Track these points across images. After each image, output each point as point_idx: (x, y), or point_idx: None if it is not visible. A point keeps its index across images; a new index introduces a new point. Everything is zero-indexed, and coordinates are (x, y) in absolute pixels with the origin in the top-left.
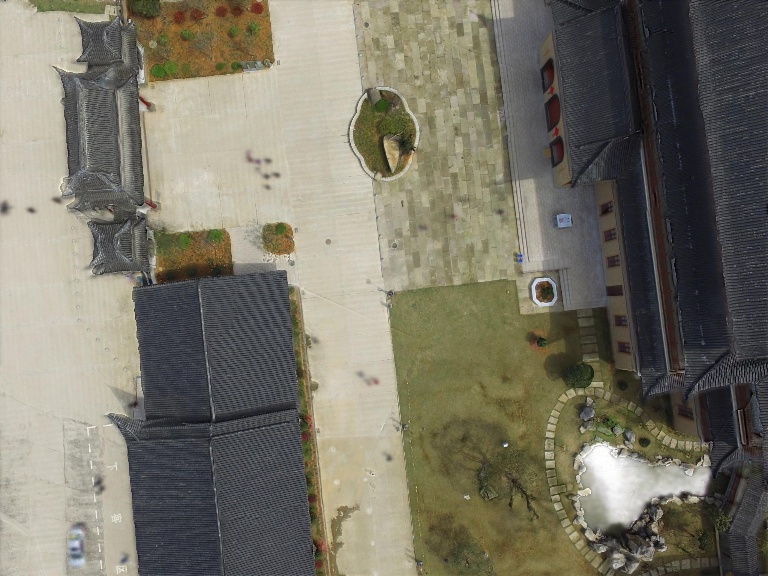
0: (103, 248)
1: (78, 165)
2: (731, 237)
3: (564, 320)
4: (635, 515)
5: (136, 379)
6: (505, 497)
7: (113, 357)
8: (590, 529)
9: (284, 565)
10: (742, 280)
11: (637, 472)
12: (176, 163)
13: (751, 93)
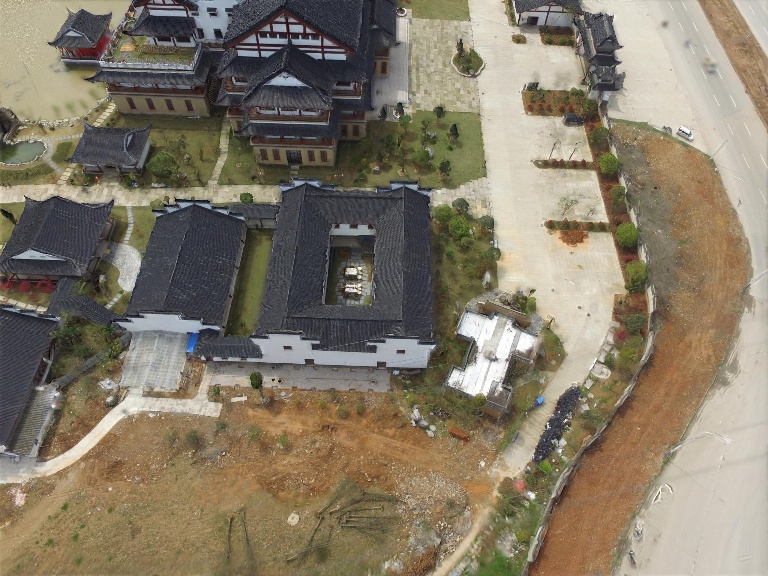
0: None
1: None
2: None
3: None
4: None
5: None
6: None
7: None
8: None
9: None
10: None
11: None
12: (569, 66)
13: None
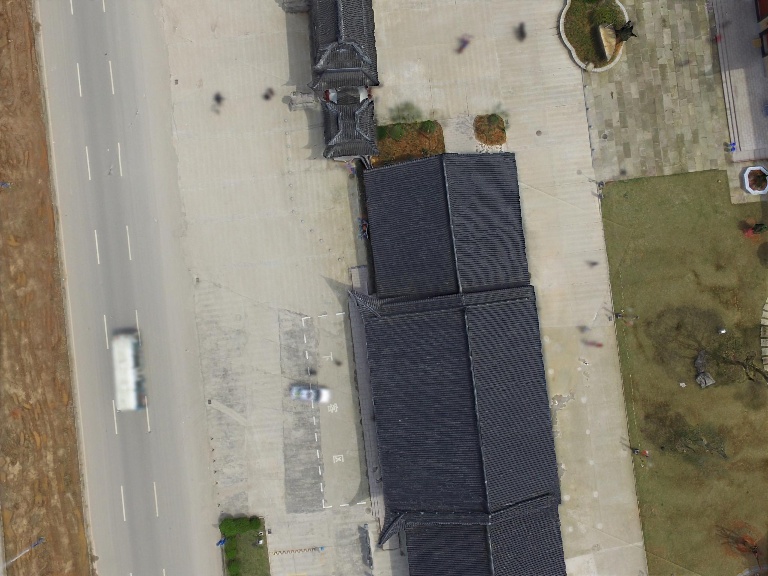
0: (343, 126)
1: (338, 33)
2: None
3: None
4: None
5: (351, 270)
6: (722, 384)
7: (327, 248)
8: None
9: (528, 439)
10: None
11: None
12: (387, 56)
13: None
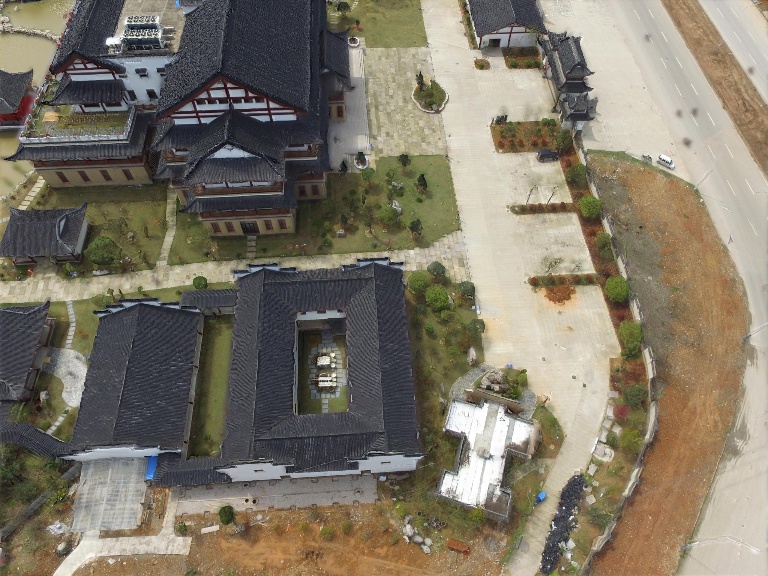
0: None
1: None
2: None
3: None
4: None
5: None
6: None
7: None
8: None
9: None
10: None
11: None
12: (537, 91)
13: None
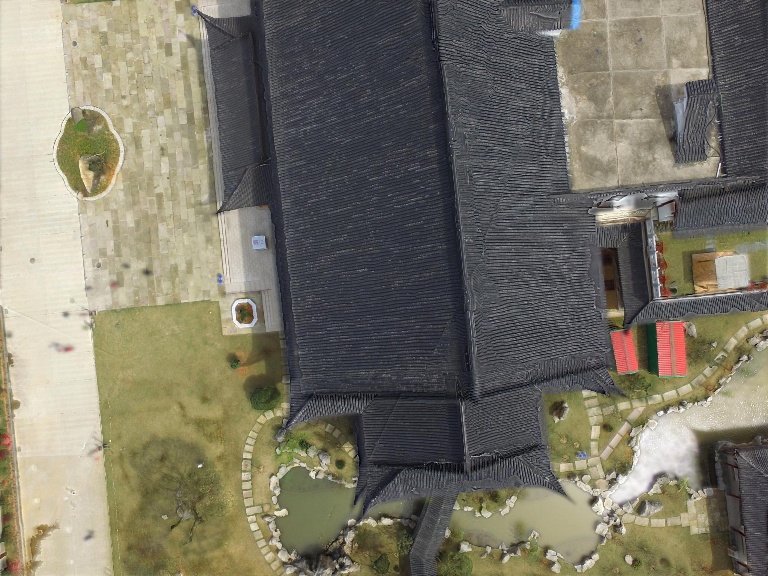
0: None
1: None
2: (296, 270)
3: (266, 341)
4: (332, 536)
5: None
6: None
7: None
8: (285, 550)
9: None
10: (304, 313)
11: (335, 493)
12: None
13: (308, 127)
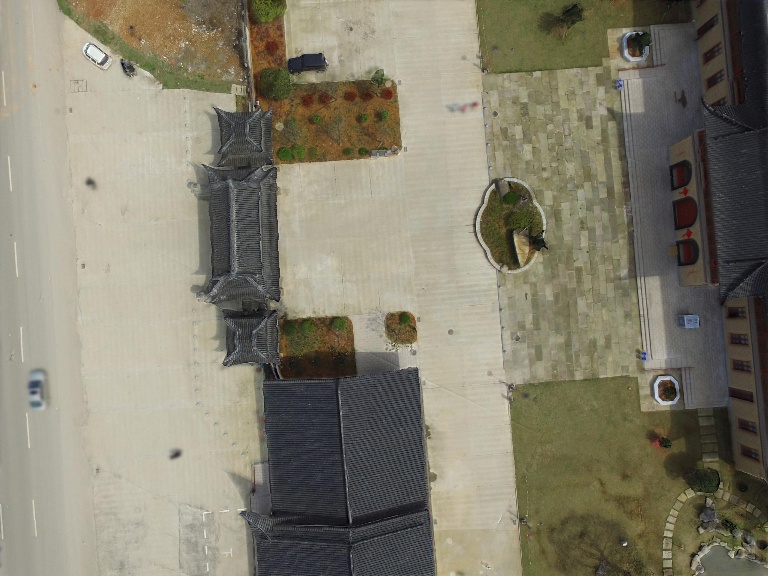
0: (240, 344)
1: (229, 269)
2: None
3: (684, 418)
4: None
5: (254, 466)
6: None
7: (231, 442)
8: None
9: None
10: None
11: (753, 573)
12: (300, 248)
13: None
